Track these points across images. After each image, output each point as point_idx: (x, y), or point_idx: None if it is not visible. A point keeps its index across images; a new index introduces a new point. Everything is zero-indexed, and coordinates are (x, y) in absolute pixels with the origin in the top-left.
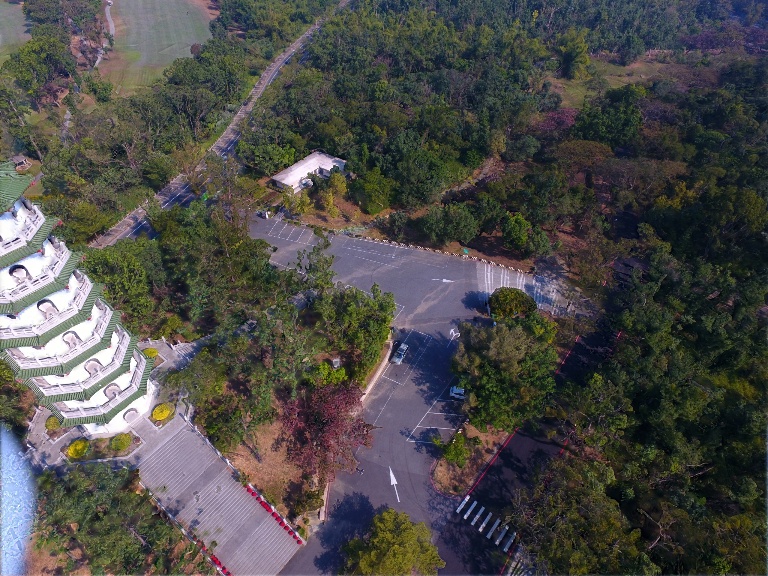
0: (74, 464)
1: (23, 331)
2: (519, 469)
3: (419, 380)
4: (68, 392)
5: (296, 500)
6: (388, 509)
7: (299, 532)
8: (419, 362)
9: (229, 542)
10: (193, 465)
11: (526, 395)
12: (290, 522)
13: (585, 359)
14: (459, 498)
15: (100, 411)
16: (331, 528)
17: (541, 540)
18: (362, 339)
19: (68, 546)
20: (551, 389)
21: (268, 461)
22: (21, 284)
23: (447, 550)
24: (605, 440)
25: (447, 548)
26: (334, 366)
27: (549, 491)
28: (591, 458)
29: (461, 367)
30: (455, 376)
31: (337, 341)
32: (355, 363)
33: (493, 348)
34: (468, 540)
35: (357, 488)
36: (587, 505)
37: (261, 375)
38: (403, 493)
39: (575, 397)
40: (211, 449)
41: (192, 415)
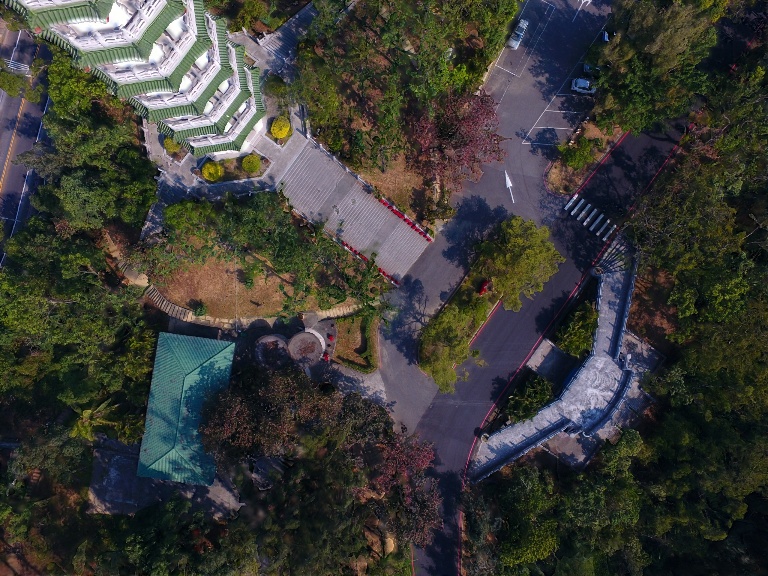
0: (212, 186)
1: (148, 74)
2: (629, 168)
3: (537, 70)
4: (198, 126)
5: (426, 208)
6: (505, 210)
7: (429, 233)
8: (538, 45)
9: (371, 244)
10: (325, 181)
11: (673, 98)
12: (419, 224)
13: (731, 32)
14: (568, 197)
15: (229, 139)
16: (454, 227)
17: (657, 243)
18: (489, 25)
19: (239, 254)
20: (703, 90)
21: (390, 171)
22: (135, 17)
23: (554, 241)
24: (736, 144)
25: (554, 239)
26: (444, 57)
27: (675, 202)
28: (702, 154)
29: (602, 61)
30: (579, 63)
31: (454, 26)
32: (466, 50)
33: (658, 42)
34: (573, 232)
35: (475, 192)
36: (709, 215)
37: (392, 91)
38: (518, 195)
39: (718, 93)
40: (338, 165)
41: (310, 130)
